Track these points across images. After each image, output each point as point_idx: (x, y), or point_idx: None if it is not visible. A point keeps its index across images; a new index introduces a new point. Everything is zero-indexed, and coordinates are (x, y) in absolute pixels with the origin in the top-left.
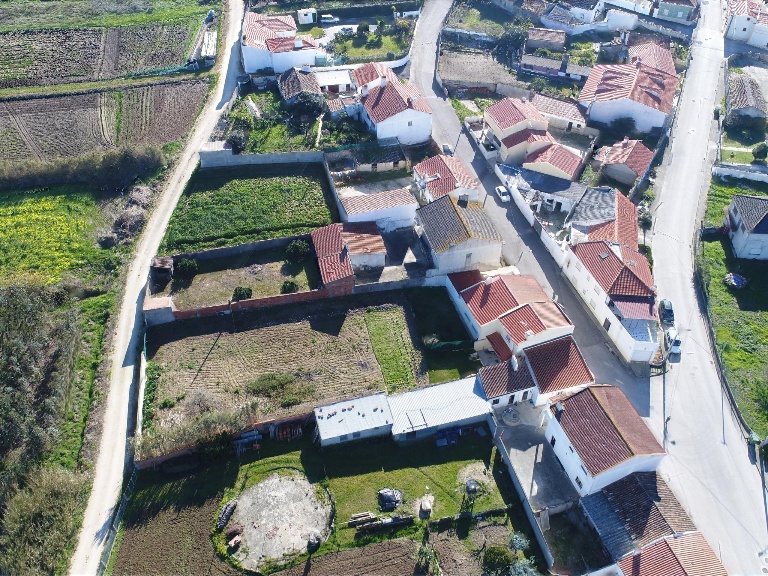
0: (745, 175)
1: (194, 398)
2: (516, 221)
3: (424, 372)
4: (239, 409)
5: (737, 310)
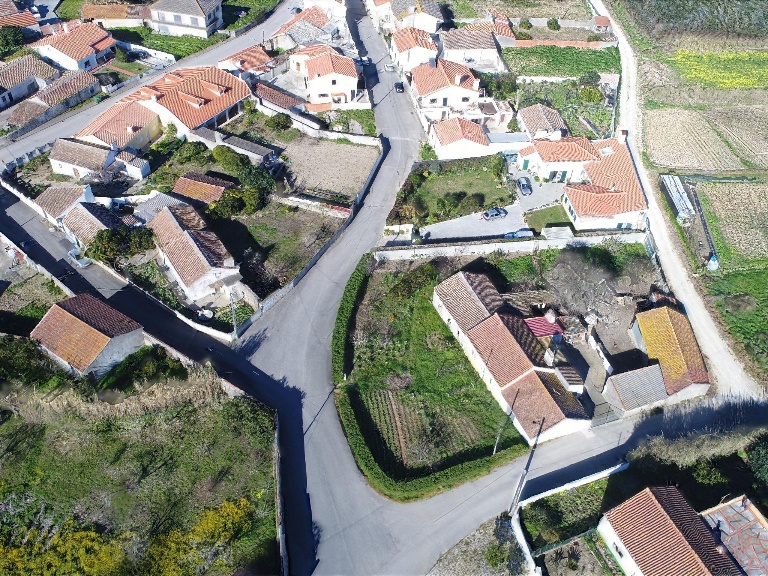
0: None
1: (566, 5)
2: (363, 50)
3: (448, 4)
4: (542, 0)
5: (253, 8)
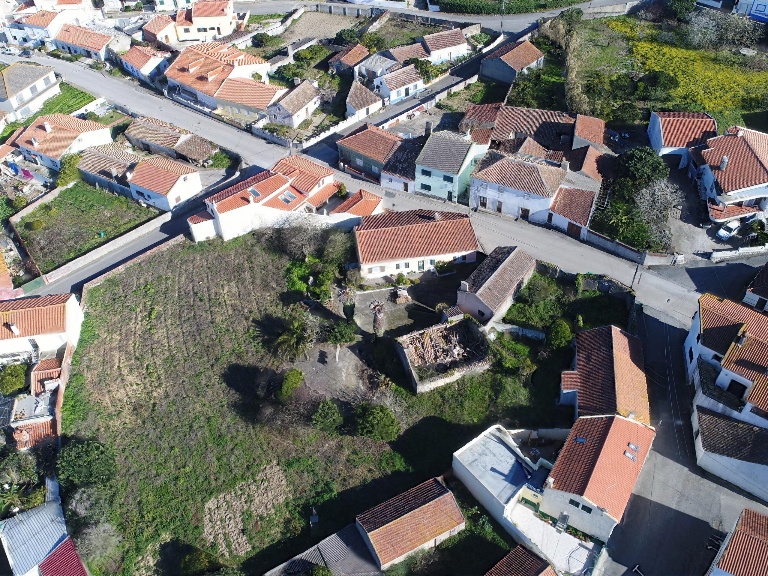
0: (84, 109)
1: None
2: None
3: None
4: None
5: None
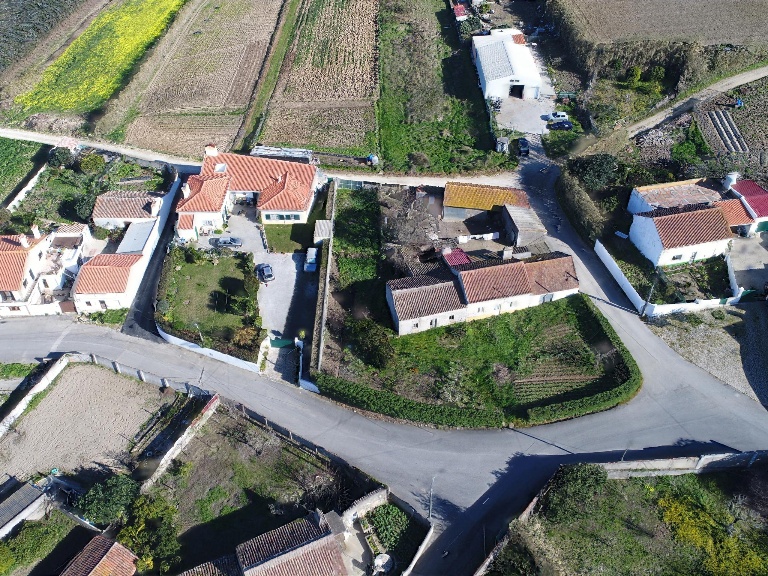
0: None
1: None
2: None
3: None
4: None
5: None
